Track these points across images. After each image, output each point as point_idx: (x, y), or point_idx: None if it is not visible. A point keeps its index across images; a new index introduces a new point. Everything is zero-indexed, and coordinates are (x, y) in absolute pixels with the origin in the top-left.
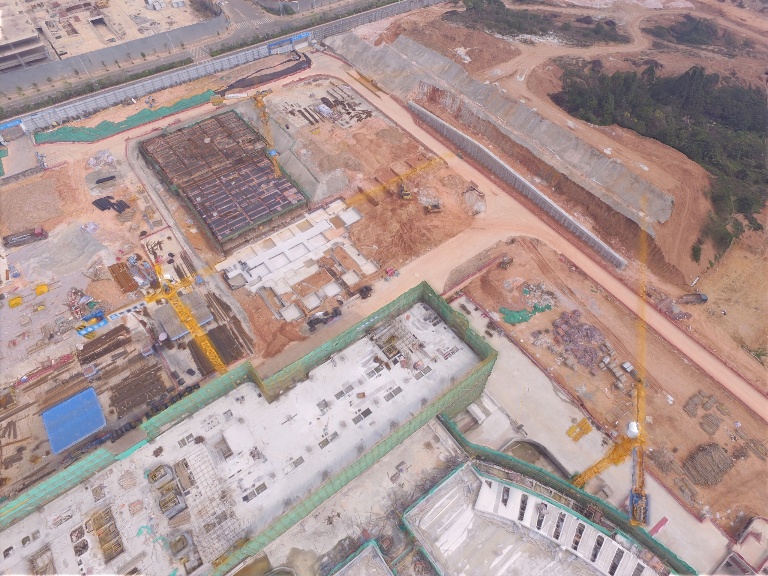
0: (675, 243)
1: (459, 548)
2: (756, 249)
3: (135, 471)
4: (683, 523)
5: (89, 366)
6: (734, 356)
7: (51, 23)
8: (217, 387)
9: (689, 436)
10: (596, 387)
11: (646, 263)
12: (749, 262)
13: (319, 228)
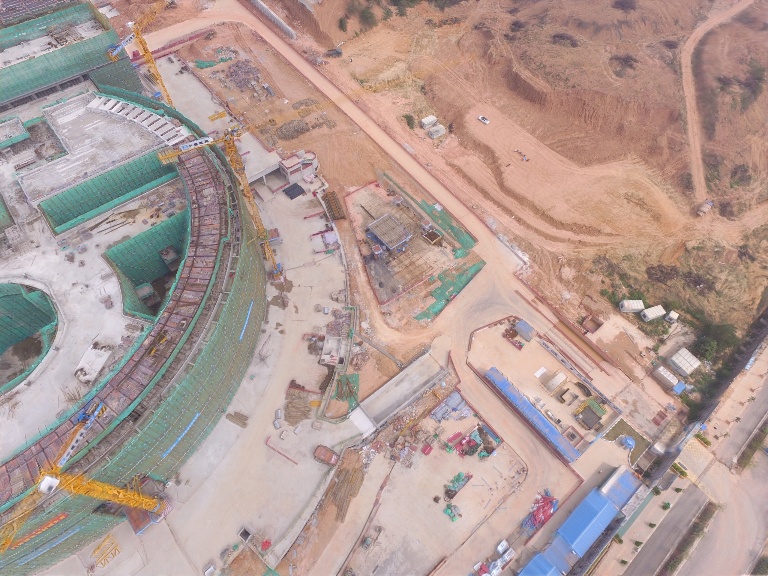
0: (328, 18)
1: (69, 121)
2: (397, 27)
3: None
4: (259, 153)
5: None
6: (346, 83)
7: None
8: None
9: (288, 118)
10: (241, 97)
11: (313, 35)
12: (389, 35)
13: None
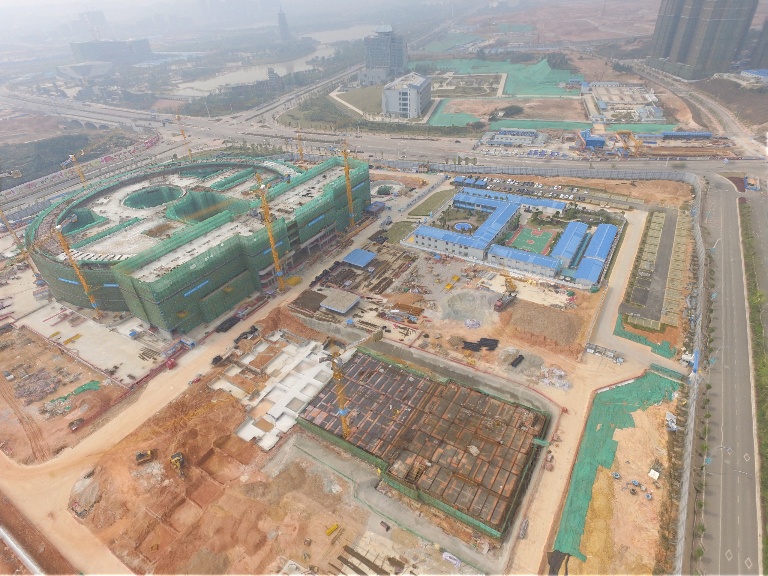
0: None
1: (151, 246)
2: None
3: (286, 220)
4: None
5: (373, 269)
6: None
7: None
8: (262, 234)
9: None
10: (45, 363)
11: None
12: None
13: (279, 406)
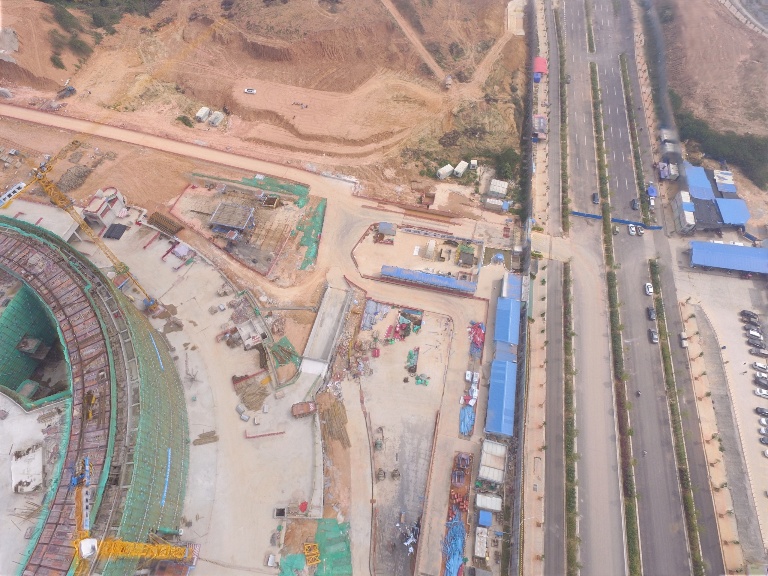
0: (36, 61)
1: None
2: (114, 46)
3: None
4: (53, 215)
5: None
6: (99, 115)
7: None
8: None
9: (61, 170)
10: None
11: (30, 86)
12: (111, 56)
13: None
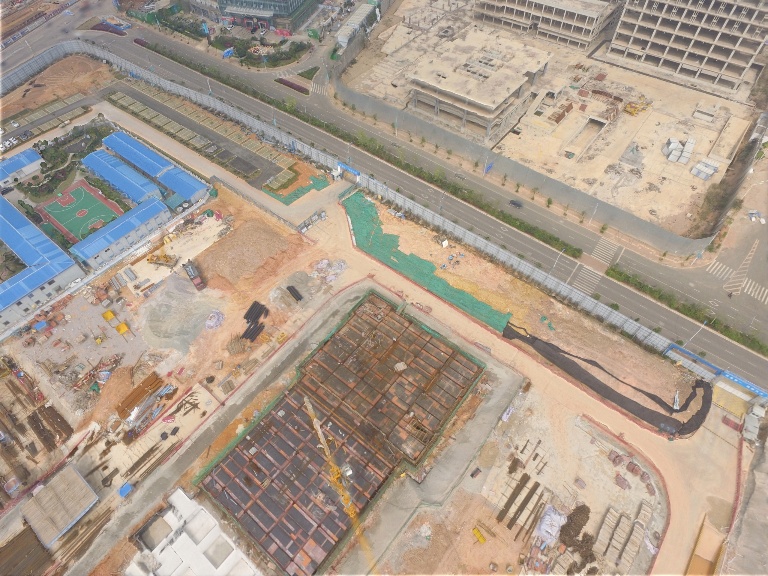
0: None
1: None
2: None
3: None
4: None
5: (1, 434)
6: None
7: (555, 95)
8: None
9: None
10: None
11: None
12: None
13: None
